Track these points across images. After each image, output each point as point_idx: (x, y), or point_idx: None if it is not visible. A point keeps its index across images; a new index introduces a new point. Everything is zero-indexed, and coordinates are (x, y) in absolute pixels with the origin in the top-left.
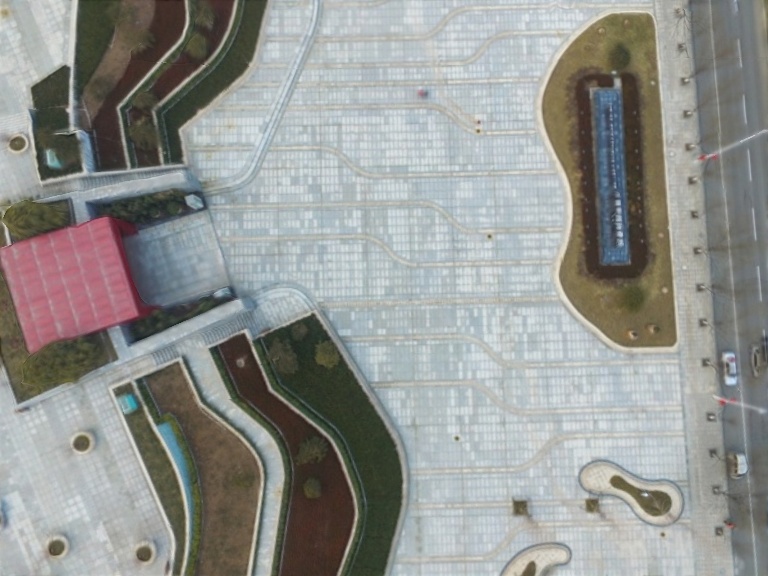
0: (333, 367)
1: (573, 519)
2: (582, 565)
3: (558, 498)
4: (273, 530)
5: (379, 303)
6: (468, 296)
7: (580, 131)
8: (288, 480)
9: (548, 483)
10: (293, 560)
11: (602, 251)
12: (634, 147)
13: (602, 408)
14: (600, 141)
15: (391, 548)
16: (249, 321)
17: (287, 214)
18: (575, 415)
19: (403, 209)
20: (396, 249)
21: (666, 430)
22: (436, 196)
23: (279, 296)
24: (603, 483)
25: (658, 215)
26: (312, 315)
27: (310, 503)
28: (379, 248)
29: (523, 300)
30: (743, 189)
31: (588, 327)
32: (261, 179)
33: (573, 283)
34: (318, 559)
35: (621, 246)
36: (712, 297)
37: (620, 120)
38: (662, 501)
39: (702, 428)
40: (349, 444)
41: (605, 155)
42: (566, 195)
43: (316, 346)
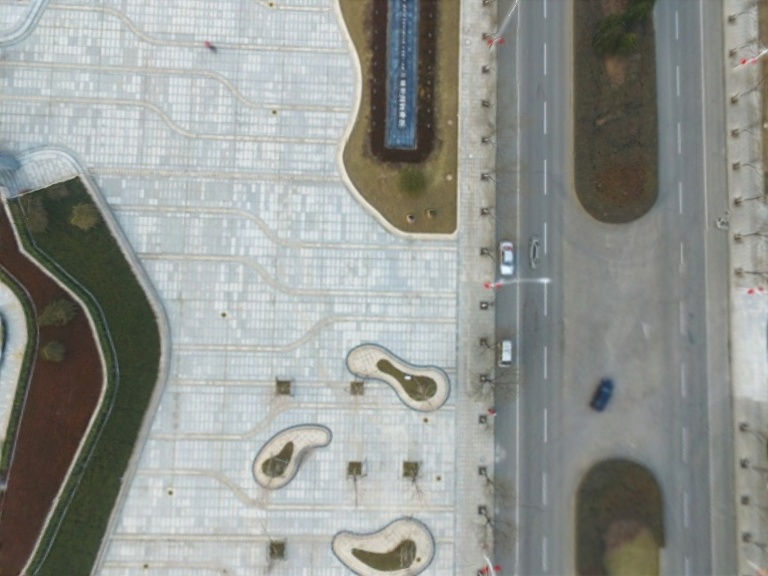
0: (90, 230)
1: (337, 401)
2: (342, 448)
3: (323, 380)
4: (11, 393)
5: (153, 172)
6: (247, 171)
7: (374, 11)
8: (32, 343)
9: (314, 364)
10: (32, 426)
11: (388, 134)
12: (427, 31)
13: (376, 292)
14: (393, 23)
15: (144, 422)
16: (9, 181)
17: (62, 75)
18: (348, 297)
19: (186, 78)
20: (175, 118)
21: (438, 317)
22: (222, 68)
23: (45, 158)
24: (370, 366)
25: (448, 102)
26: (76, 178)
27: (53, 368)
28: (157, 116)
29: (304, 179)
30: (537, 83)
31: (369, 210)
32: (36, 37)
33: (356, 164)
34: (59, 427)
35: (403, 127)
36: (494, 186)
37: (415, 3)
38: (427, 386)
39: (474, 316)
40: (105, 312)
41: (397, 37)
42: (356, 76)
43: (74, 207)
